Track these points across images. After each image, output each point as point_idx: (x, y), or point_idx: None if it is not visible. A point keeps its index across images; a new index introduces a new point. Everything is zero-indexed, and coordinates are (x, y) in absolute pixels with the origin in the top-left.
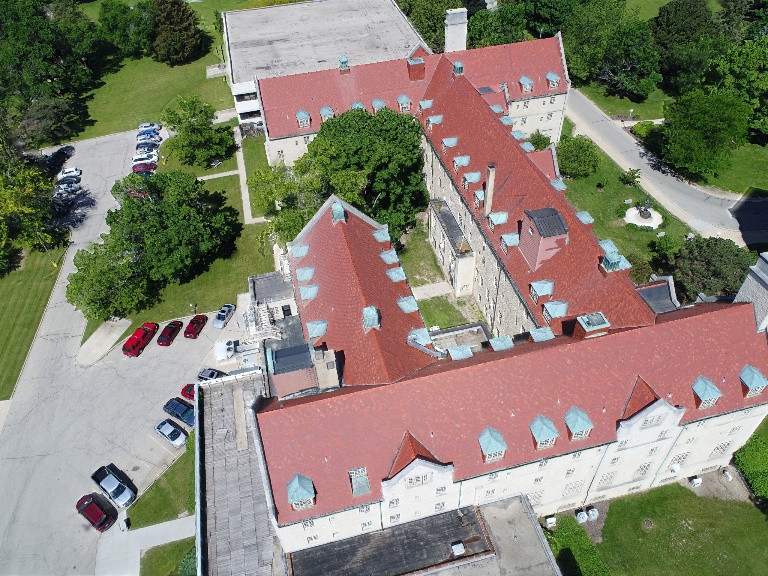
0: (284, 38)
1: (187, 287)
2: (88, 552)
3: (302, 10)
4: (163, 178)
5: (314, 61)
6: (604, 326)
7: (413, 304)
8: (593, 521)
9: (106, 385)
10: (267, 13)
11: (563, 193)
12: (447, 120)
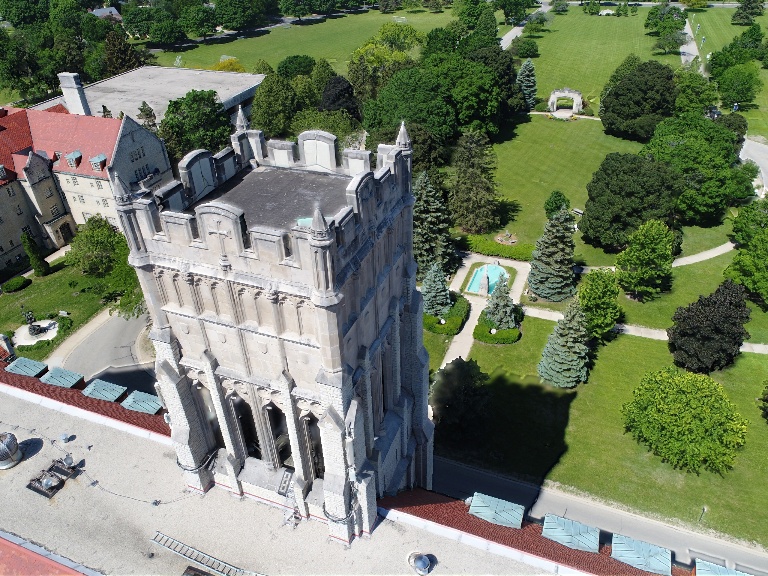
0: (126, 91)
1: None
2: None
3: (189, 75)
4: None
5: (97, 111)
6: None
7: None
8: None
9: None
10: (166, 72)
11: None
12: None
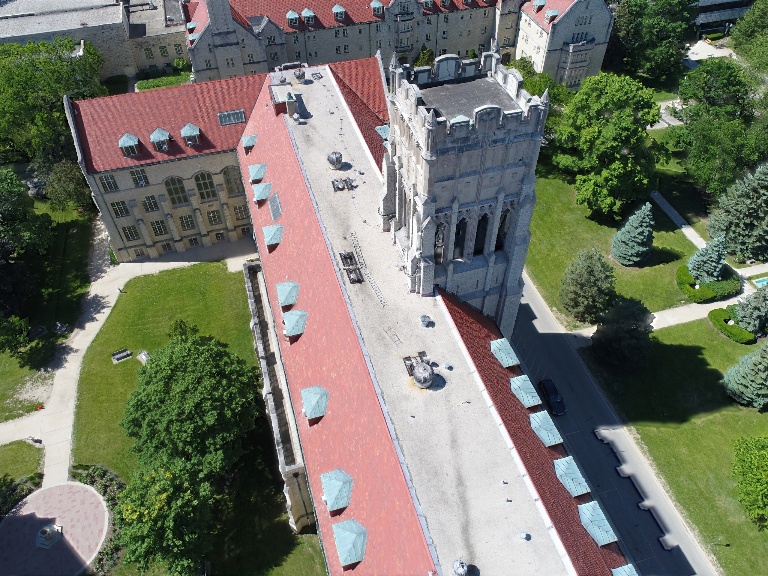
0: None
1: None
2: None
3: None
4: None
5: None
6: None
7: None
8: None
9: None
10: None
11: (372, 11)
12: None
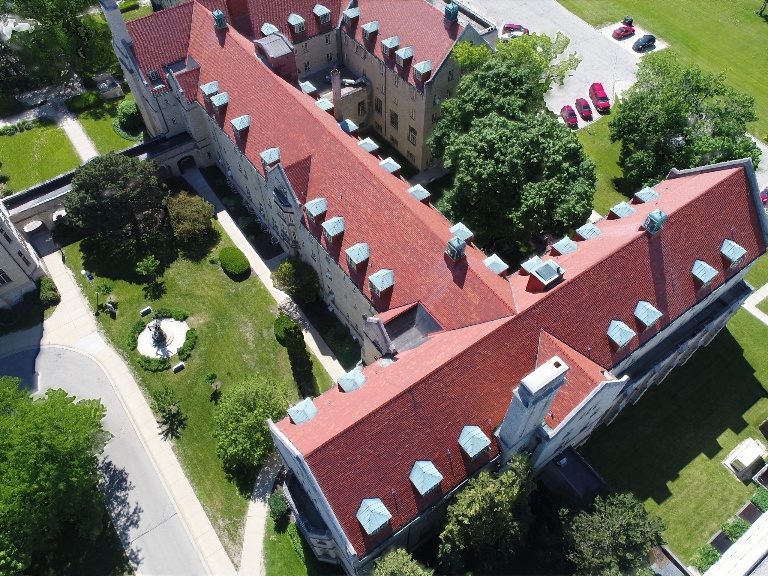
0: None
1: (617, 145)
2: (503, 25)
3: None
4: (726, 128)
5: None
6: None
7: (366, 26)
8: None
9: (588, 76)
10: None
11: None
12: (439, 221)
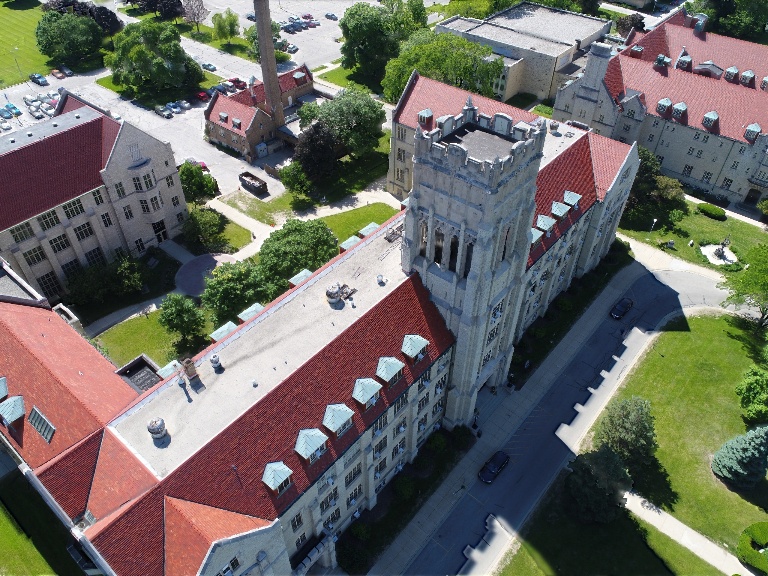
0: None
1: None
2: None
3: None
4: None
5: None
6: None
7: None
8: None
9: None
10: None
11: None
12: None
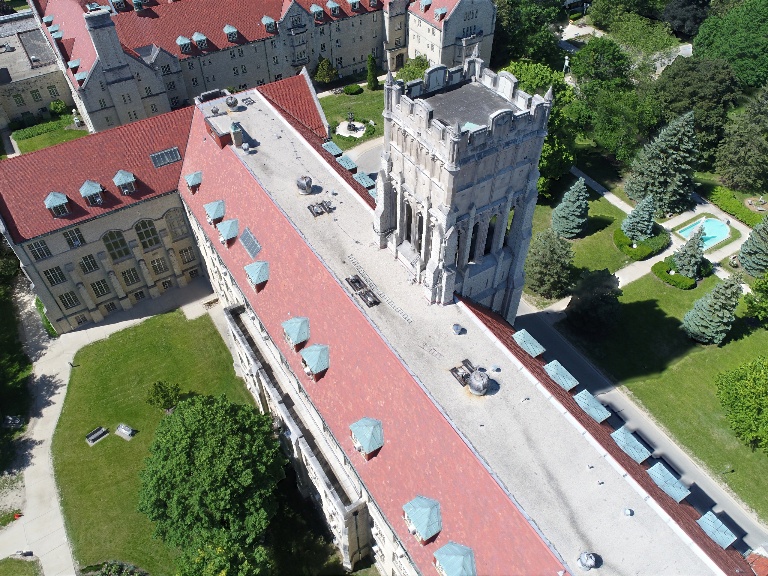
0: None
1: None
2: None
3: None
4: None
5: None
6: (89, 8)
7: None
8: (76, 126)
9: None
10: None
11: None
12: None
